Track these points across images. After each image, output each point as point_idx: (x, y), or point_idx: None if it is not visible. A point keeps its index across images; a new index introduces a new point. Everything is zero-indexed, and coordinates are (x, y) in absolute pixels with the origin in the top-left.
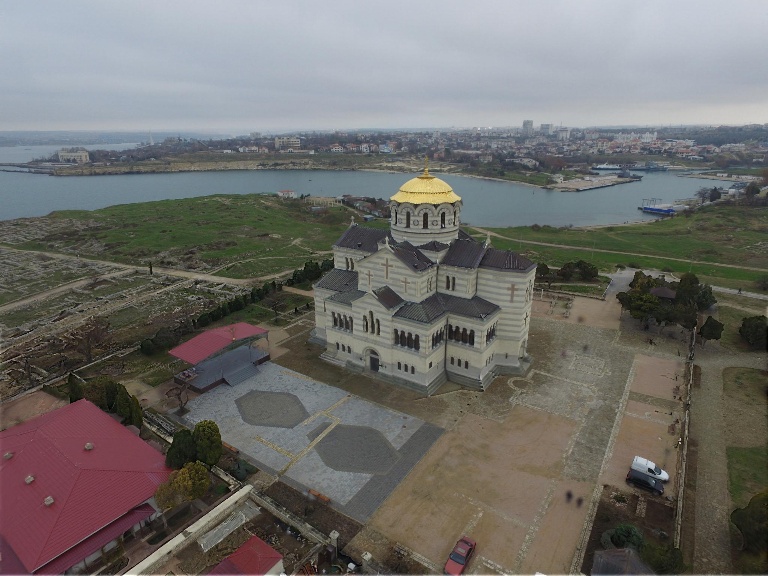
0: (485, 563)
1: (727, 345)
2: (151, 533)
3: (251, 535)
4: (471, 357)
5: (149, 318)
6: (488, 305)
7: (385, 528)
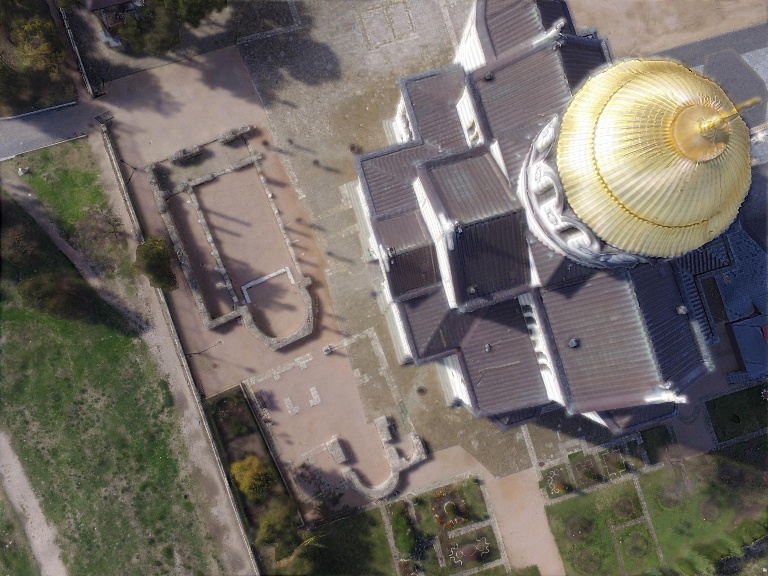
0: None
1: None
2: None
3: None
4: None
5: None
6: None
7: (766, 6)
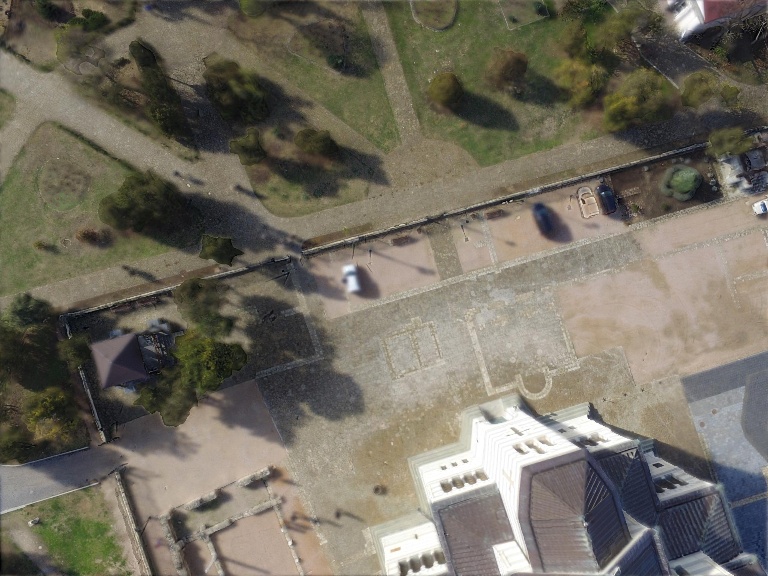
0: None
1: (190, 237)
2: None
3: None
4: None
5: None
6: None
7: None
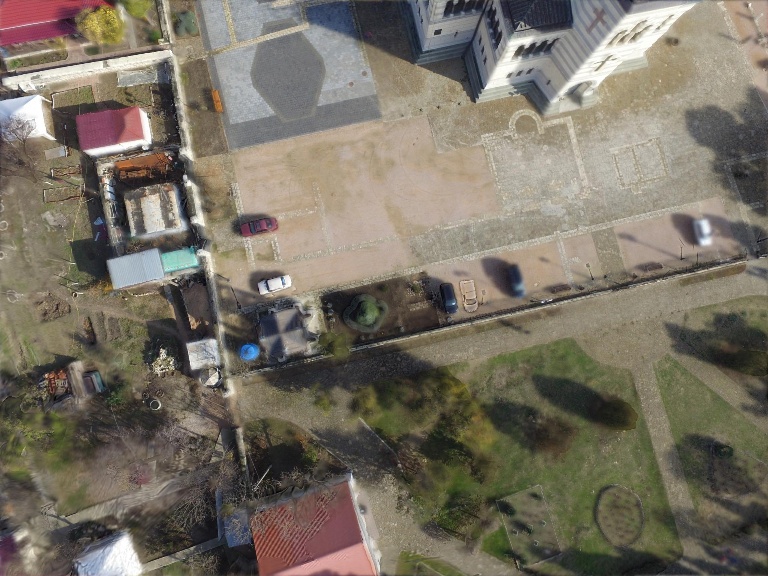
0: (273, 242)
1: None
2: (88, 43)
3: (151, 98)
4: (490, 58)
5: None
6: (561, 8)
7: (240, 166)
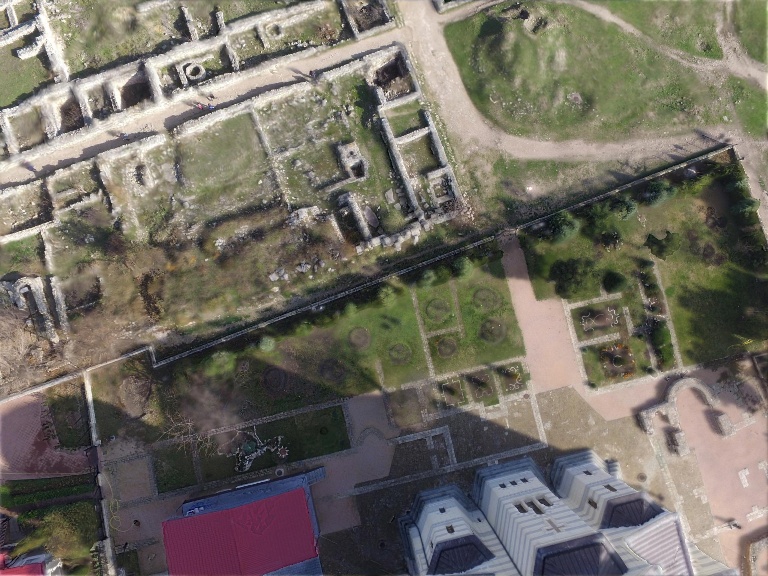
0: None
1: None
2: None
3: None
4: None
5: (256, 191)
6: None
7: None
